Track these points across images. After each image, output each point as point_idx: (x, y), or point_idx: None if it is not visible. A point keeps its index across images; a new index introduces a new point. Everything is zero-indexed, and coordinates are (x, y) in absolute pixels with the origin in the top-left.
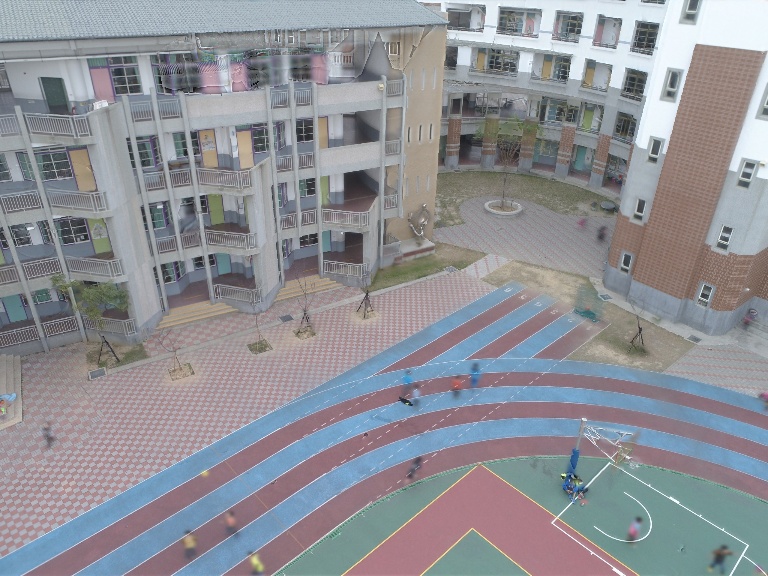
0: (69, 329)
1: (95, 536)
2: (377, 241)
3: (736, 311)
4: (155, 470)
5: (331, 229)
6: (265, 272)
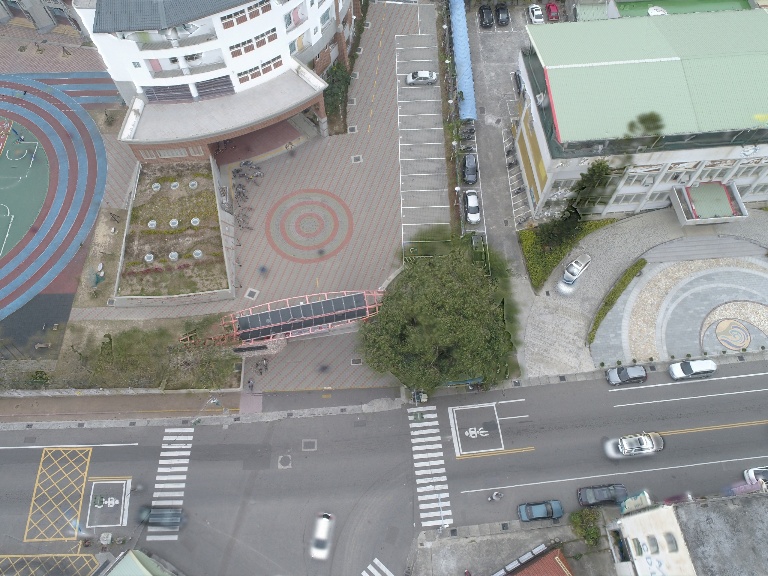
0: None
1: None
2: None
3: None
4: None
5: None
6: (36, 18)
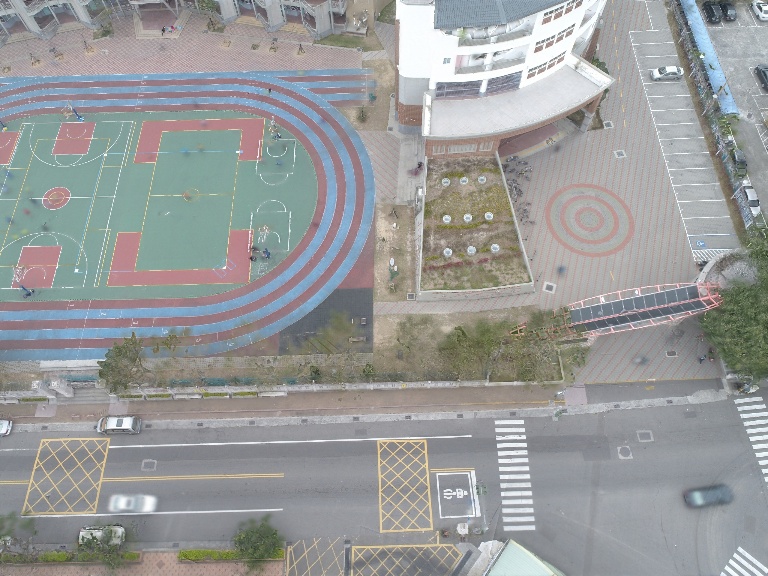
0: (207, 9)
1: (171, 80)
2: (329, 21)
3: (408, 127)
4: (194, 71)
5: (304, 8)
6: (271, 17)
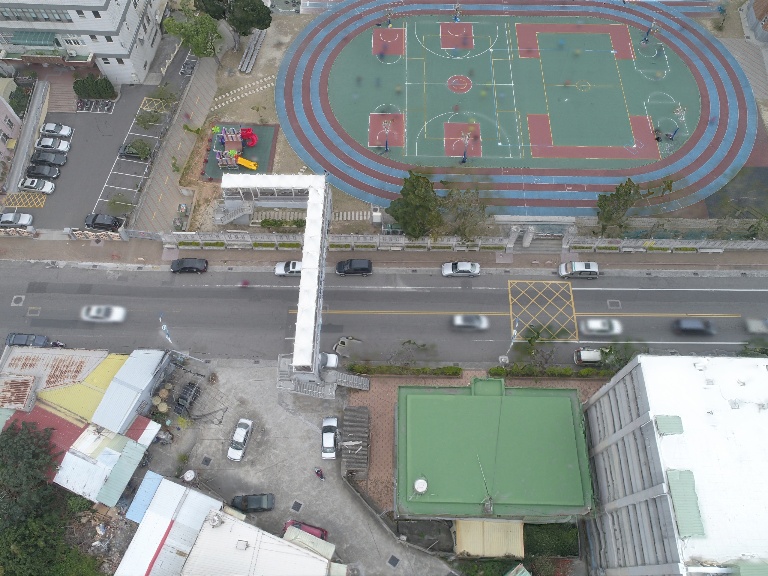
0: None
1: None
2: None
3: None
4: None
5: None
6: None
